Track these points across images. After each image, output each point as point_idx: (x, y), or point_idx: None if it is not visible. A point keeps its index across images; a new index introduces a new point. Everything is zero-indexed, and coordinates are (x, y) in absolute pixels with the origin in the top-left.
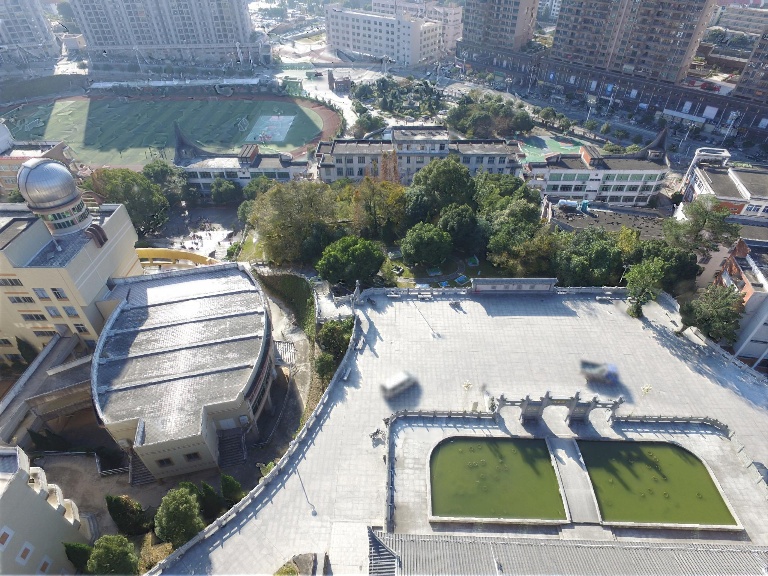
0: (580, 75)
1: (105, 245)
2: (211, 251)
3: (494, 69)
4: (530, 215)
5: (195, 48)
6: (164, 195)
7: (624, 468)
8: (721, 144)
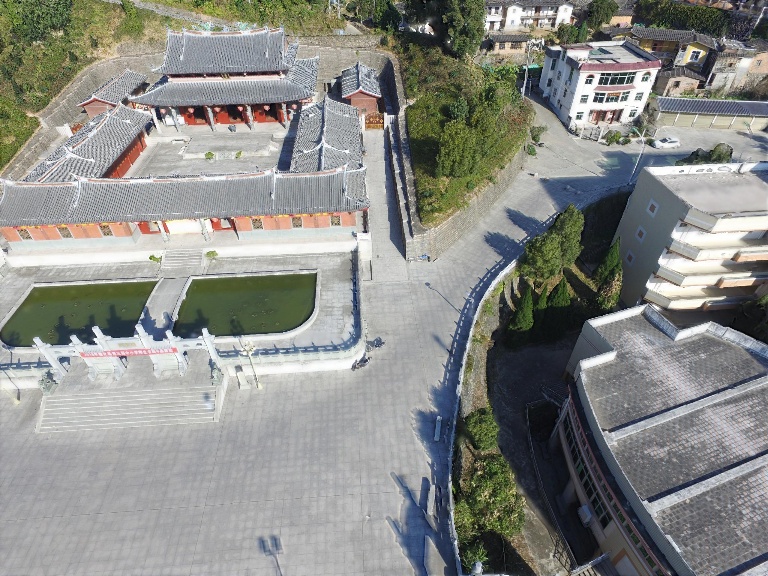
0: None
1: None
2: None
3: None
4: None
5: None
6: None
7: (98, 322)
8: None
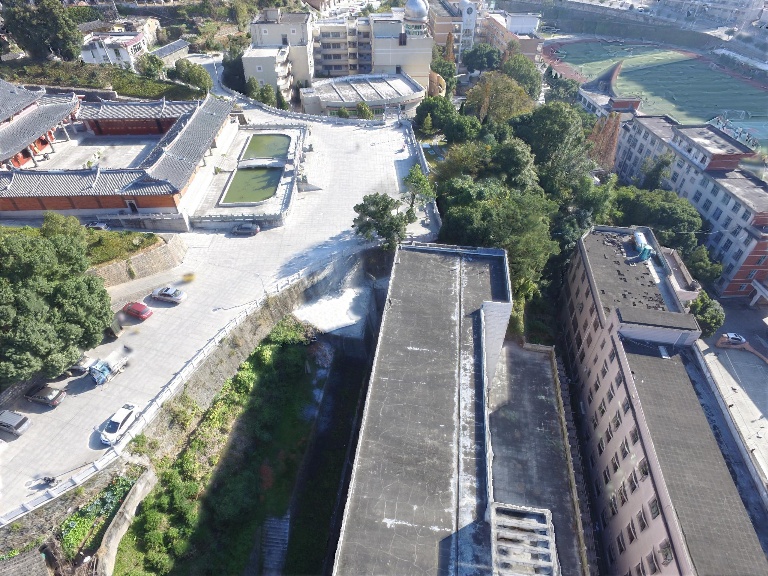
0: None
1: (405, 48)
2: None
3: None
4: (509, 154)
5: None
6: None
7: None
8: None
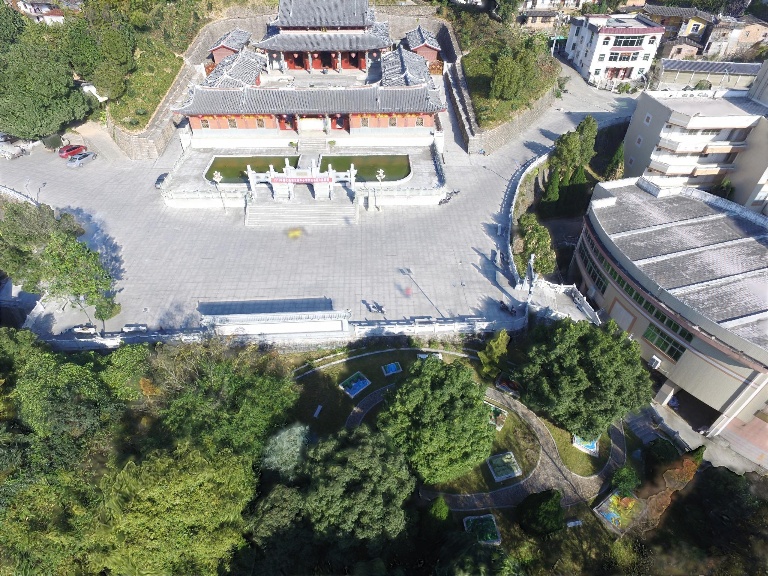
0: None
1: None
2: None
3: None
4: None
5: None
6: None
7: None
8: None
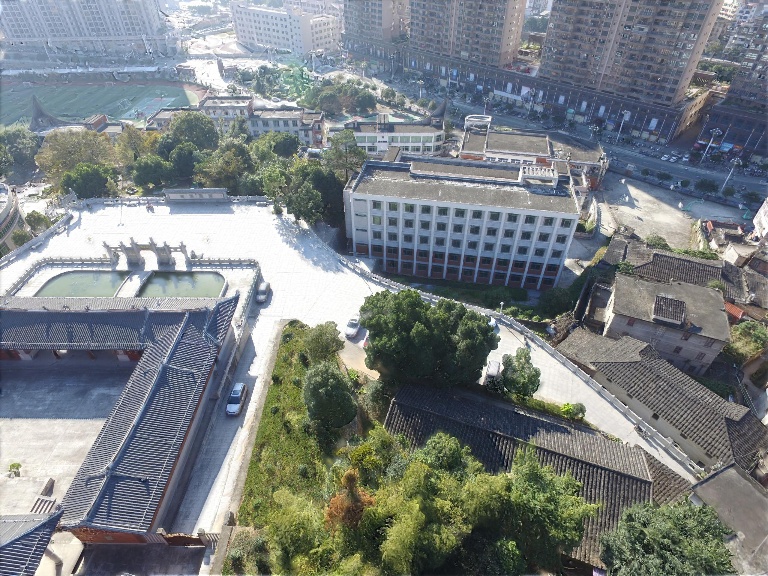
0: (433, 62)
1: None
2: (32, 193)
3: (370, 58)
4: (235, 149)
5: (107, 40)
6: (13, 154)
7: (172, 284)
8: (527, 118)
